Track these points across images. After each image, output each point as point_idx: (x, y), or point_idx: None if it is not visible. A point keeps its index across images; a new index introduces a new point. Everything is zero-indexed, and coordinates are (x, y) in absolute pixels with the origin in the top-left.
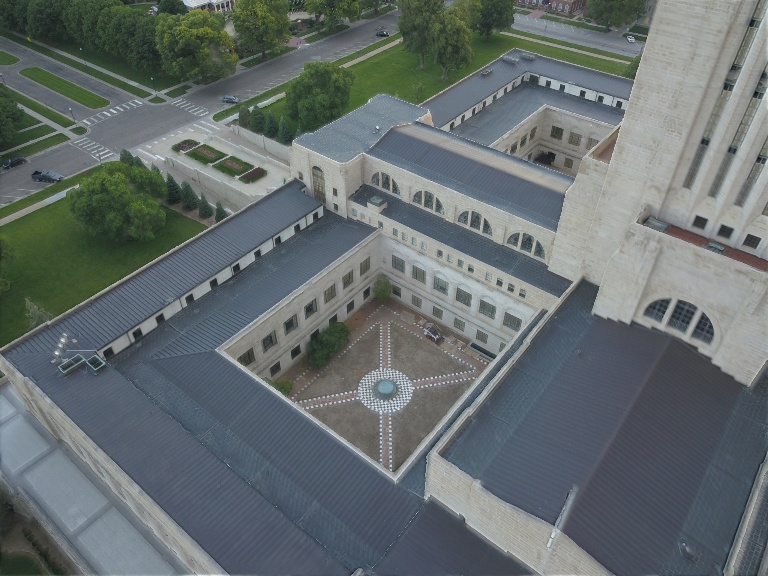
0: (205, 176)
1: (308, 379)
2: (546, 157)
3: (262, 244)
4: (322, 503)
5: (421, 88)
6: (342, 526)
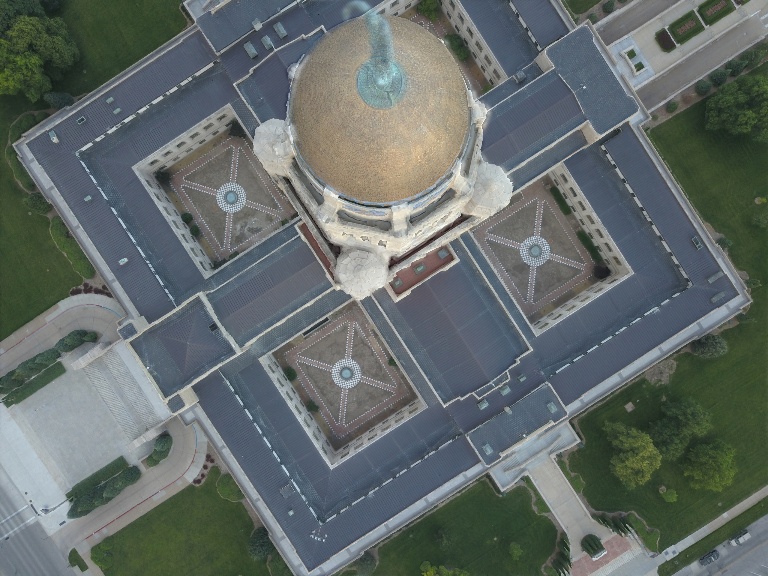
0: (677, 2)
1: (442, 35)
2: (600, 272)
3: (512, 2)
4: (340, 1)
5: (759, 221)
6: (328, 6)
